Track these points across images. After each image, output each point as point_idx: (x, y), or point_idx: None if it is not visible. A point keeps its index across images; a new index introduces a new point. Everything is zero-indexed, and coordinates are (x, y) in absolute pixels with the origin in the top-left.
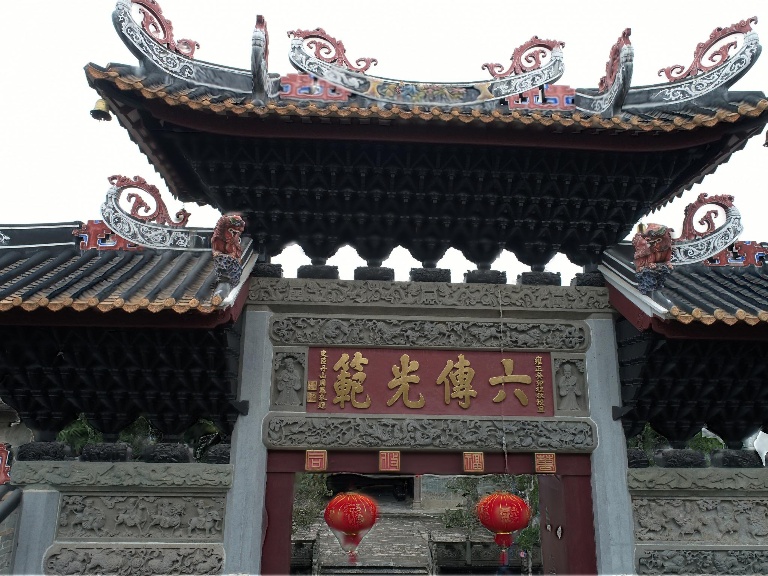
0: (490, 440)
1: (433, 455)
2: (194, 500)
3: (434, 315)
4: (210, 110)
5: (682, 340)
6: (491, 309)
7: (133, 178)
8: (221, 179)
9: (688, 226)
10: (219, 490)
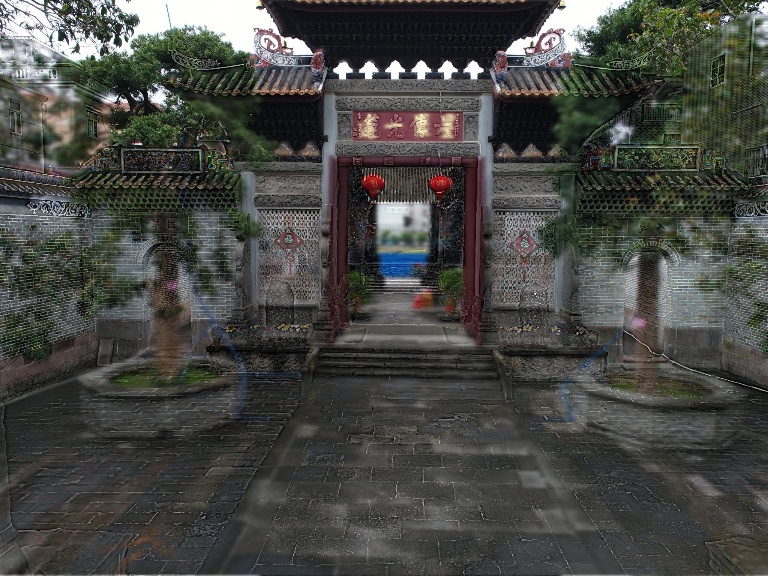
0: (433, 152)
1: (408, 159)
2: (308, 177)
3: (409, 95)
4: (305, 2)
5: (512, 103)
6: (435, 92)
7: (266, 30)
8: (309, 31)
9: (538, 46)
10: (318, 173)
